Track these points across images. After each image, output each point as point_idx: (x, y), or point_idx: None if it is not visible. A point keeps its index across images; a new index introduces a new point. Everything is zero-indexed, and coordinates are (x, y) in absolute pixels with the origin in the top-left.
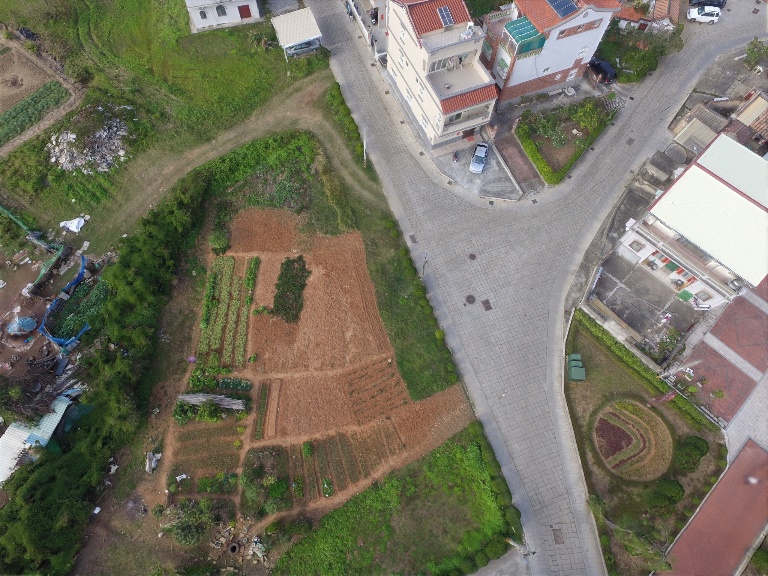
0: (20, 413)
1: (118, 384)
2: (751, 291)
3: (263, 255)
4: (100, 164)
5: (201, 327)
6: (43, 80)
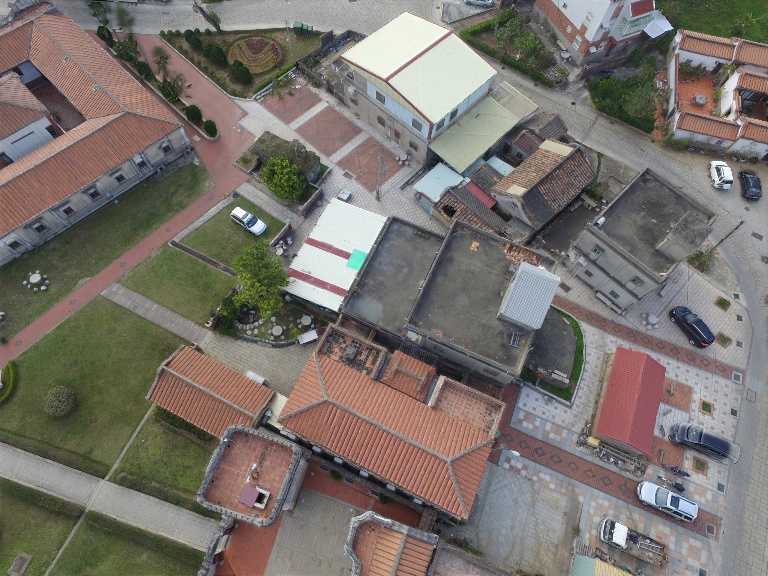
0: None
1: None
2: (366, 139)
3: None
4: None
5: None
6: None
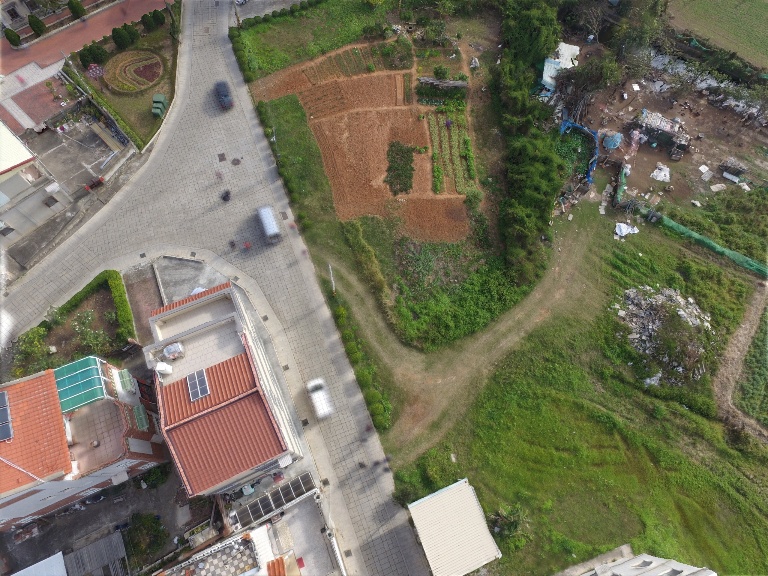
0: None
1: (512, 84)
2: None
3: (431, 195)
4: (637, 295)
5: (469, 138)
6: None
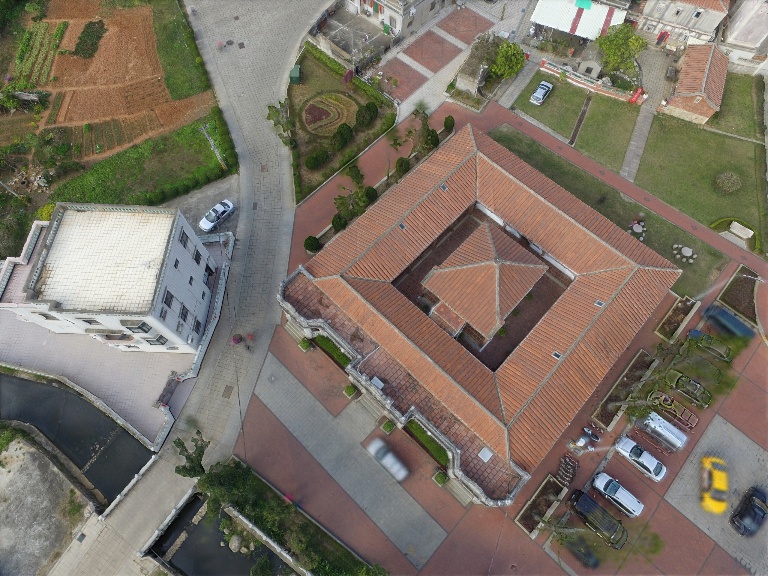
0: None
1: None
2: (440, 28)
3: (71, 20)
4: None
5: (16, 63)
6: None
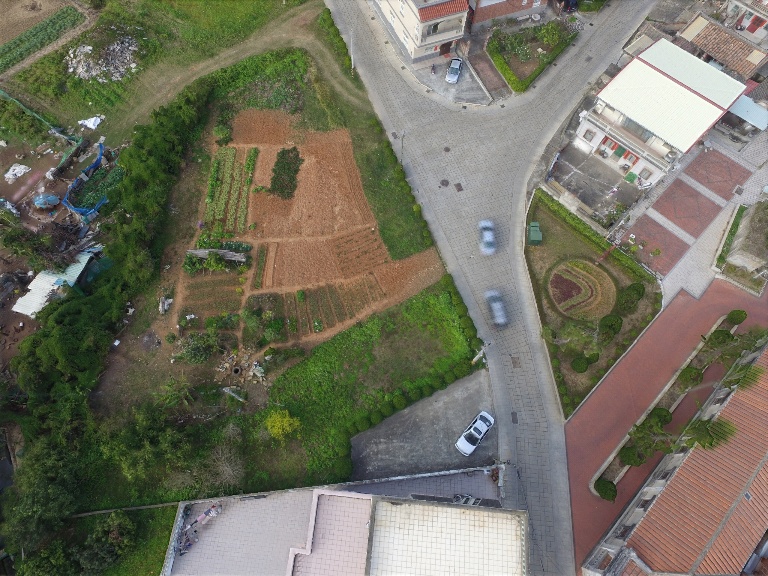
0: (49, 259)
1: (135, 238)
2: (689, 176)
3: (261, 146)
4: (114, 74)
5: (207, 202)
6: (60, 6)
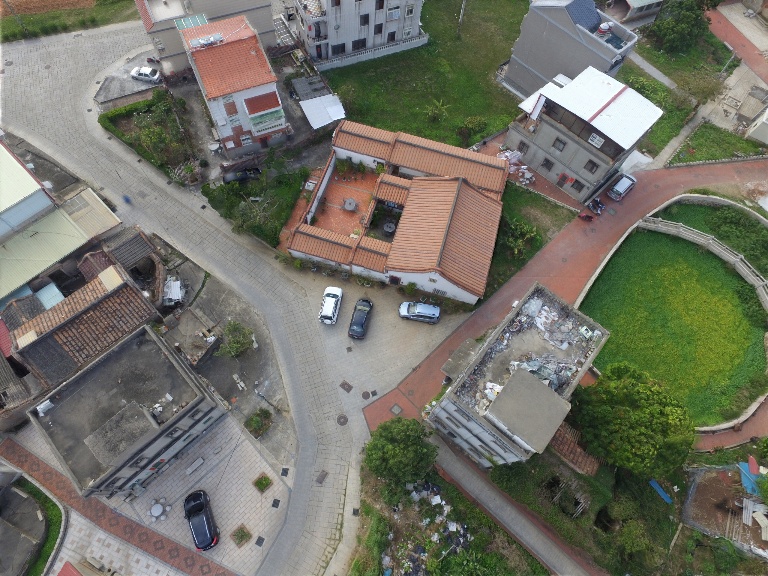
0: None
1: None
2: None
3: None
4: None
5: None
6: None
